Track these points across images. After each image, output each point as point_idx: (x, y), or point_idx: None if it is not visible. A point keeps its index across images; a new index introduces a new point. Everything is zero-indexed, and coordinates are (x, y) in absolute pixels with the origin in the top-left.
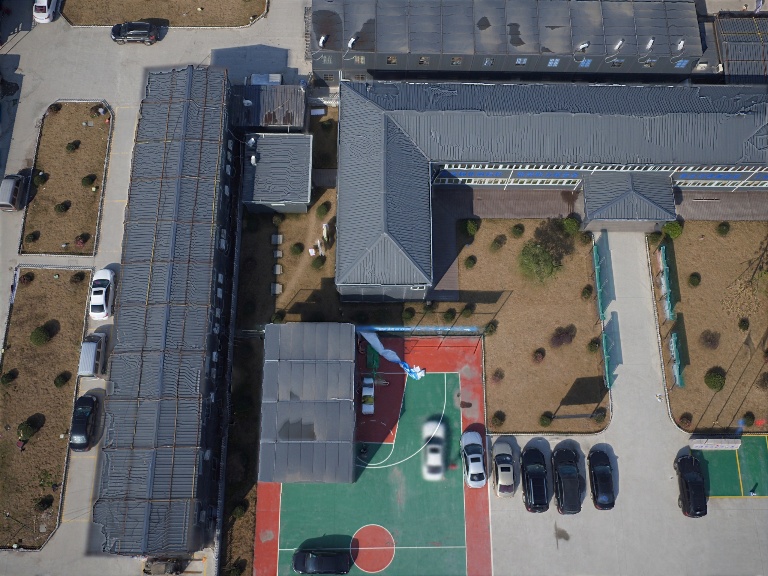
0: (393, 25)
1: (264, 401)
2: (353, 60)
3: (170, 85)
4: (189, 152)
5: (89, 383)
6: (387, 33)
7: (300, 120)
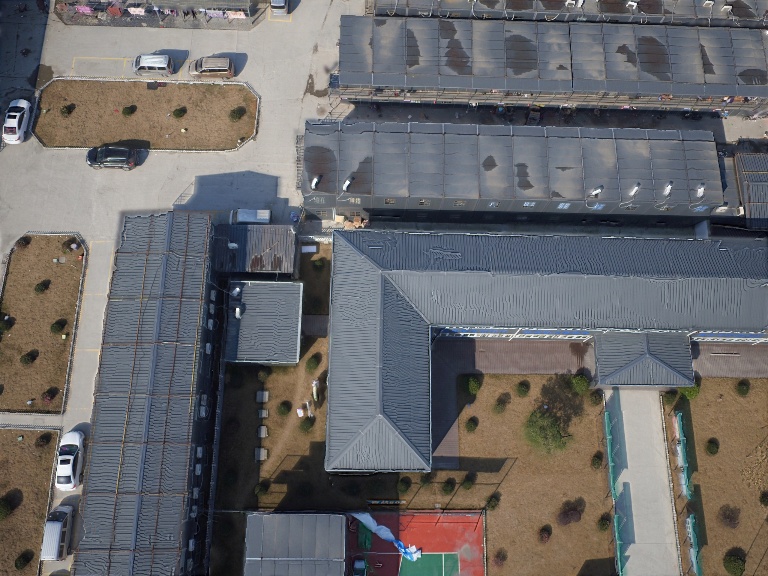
0: (392, 164)
1: None
2: (348, 201)
3: (148, 232)
4: (167, 312)
5: (53, 564)
6: (385, 174)
7: (289, 265)
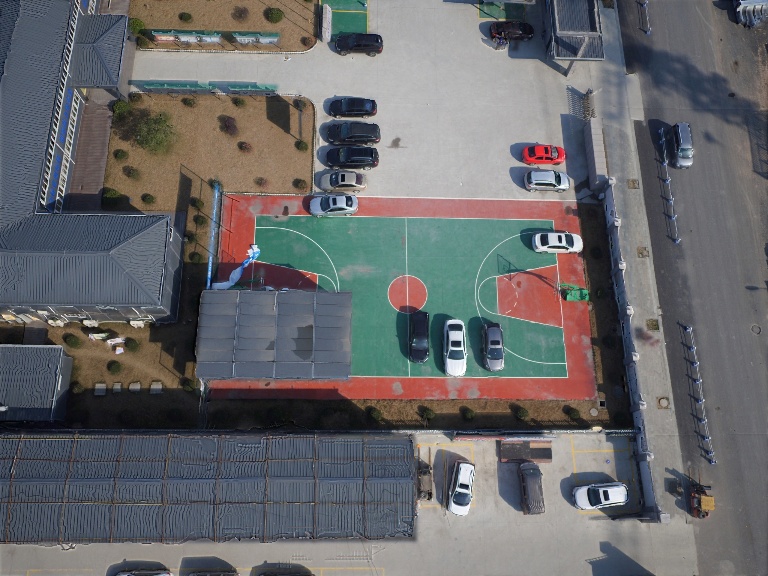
0: None
1: (273, 375)
2: None
3: None
4: None
5: None
6: None
7: None
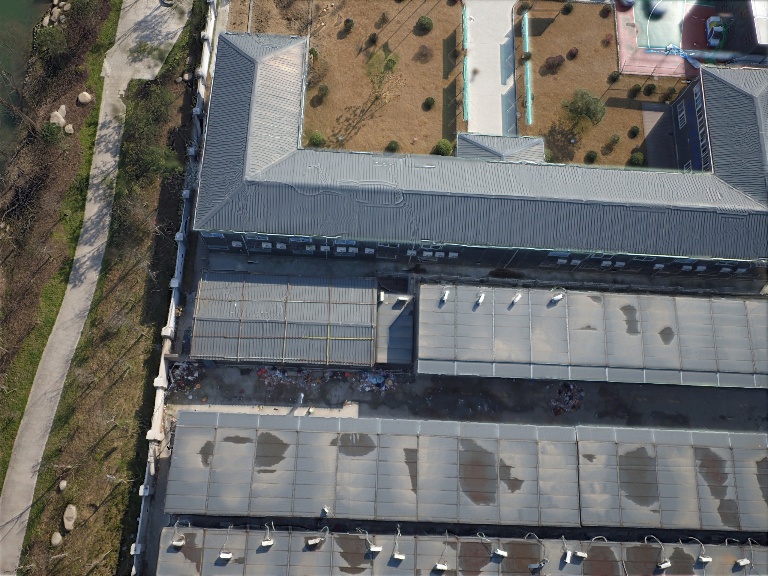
0: (767, 338)
1: None
2: None
3: None
4: None
5: None
6: None
7: None
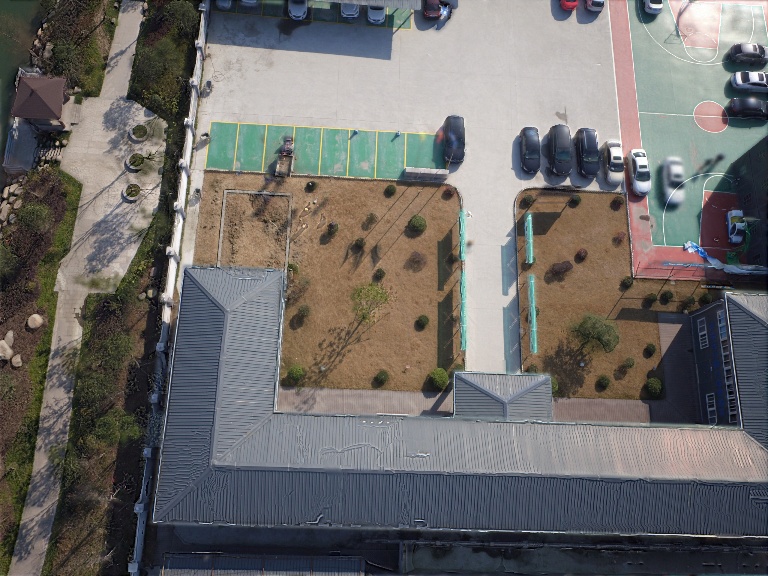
0: None
1: None
2: None
3: None
4: None
5: None
6: None
7: None
